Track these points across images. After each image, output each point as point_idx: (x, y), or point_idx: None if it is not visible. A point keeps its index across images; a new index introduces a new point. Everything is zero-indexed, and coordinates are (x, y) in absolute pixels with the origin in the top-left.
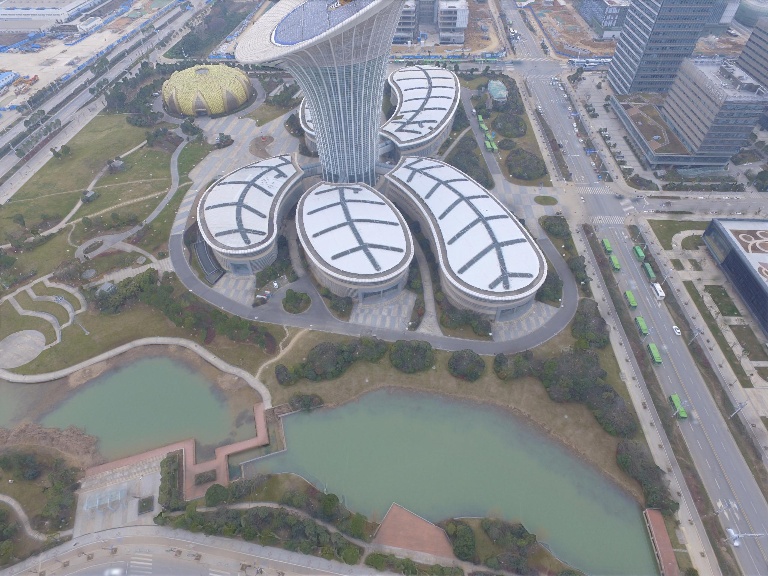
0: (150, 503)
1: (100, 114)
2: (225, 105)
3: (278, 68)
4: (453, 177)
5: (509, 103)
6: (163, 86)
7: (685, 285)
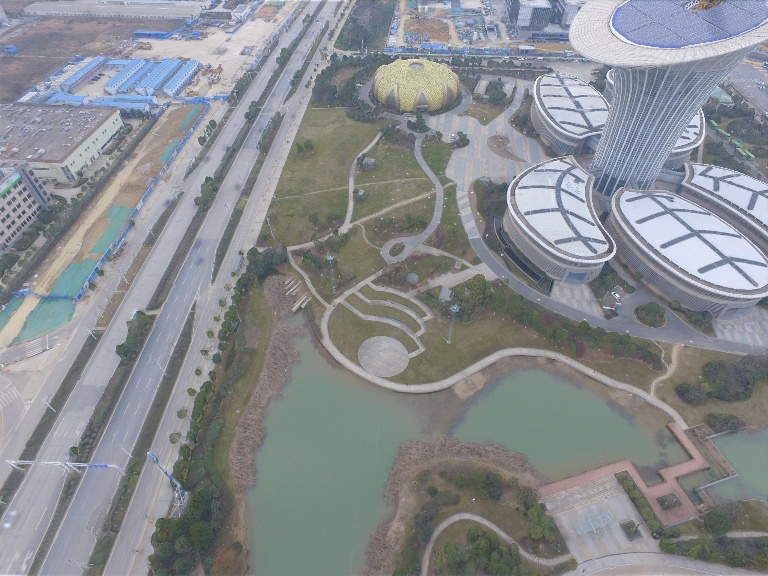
0: None
1: (310, 107)
2: (444, 102)
3: None
4: (763, 187)
5: (742, 108)
6: (378, 80)
7: None
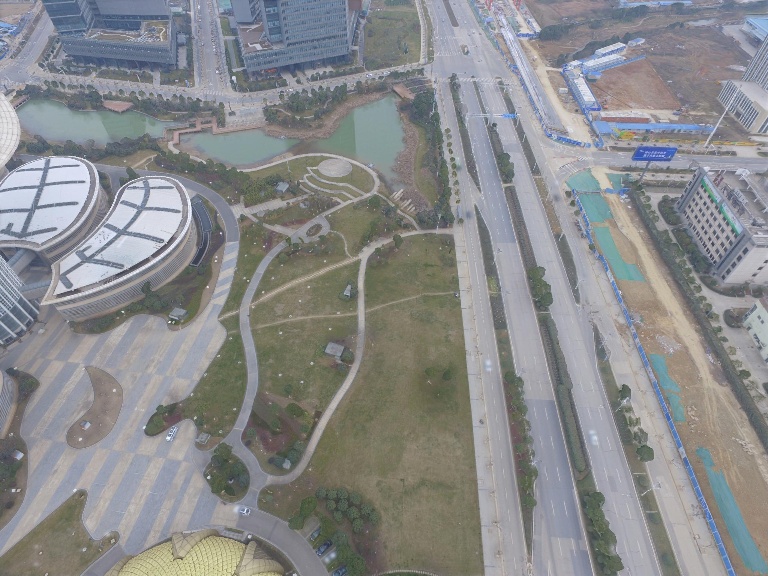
0: (229, 113)
1: None
2: None
3: None
4: None
5: None
6: None
7: None
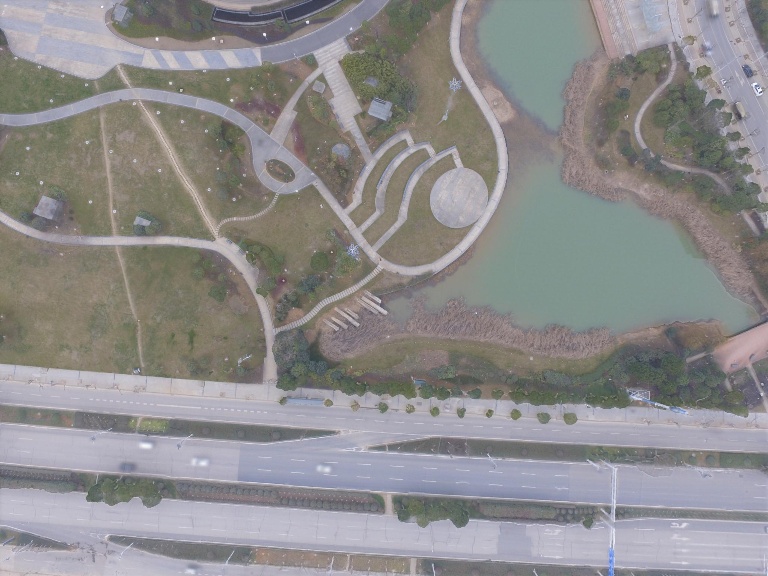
0: None
1: None
2: None
3: None
4: None
5: None
6: None
7: None
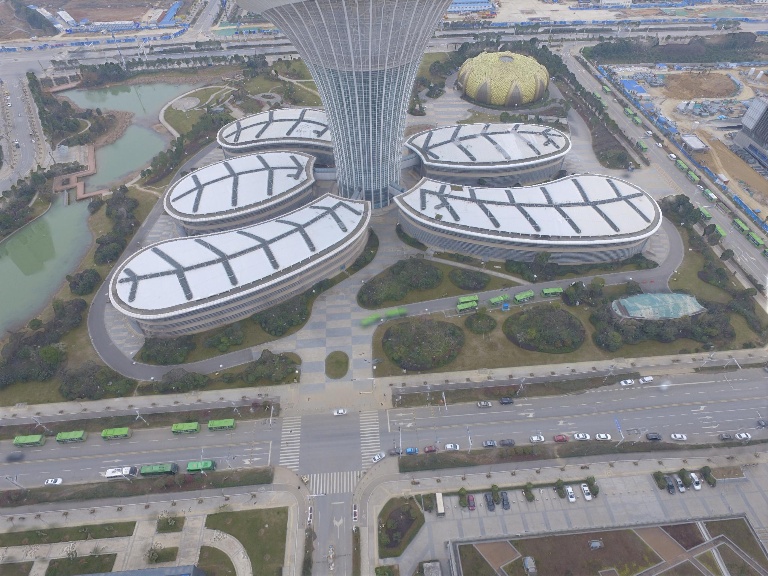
0: None
1: (449, 52)
2: (475, 93)
3: (604, 108)
4: (314, 236)
5: (602, 316)
6: None
7: (126, 522)
